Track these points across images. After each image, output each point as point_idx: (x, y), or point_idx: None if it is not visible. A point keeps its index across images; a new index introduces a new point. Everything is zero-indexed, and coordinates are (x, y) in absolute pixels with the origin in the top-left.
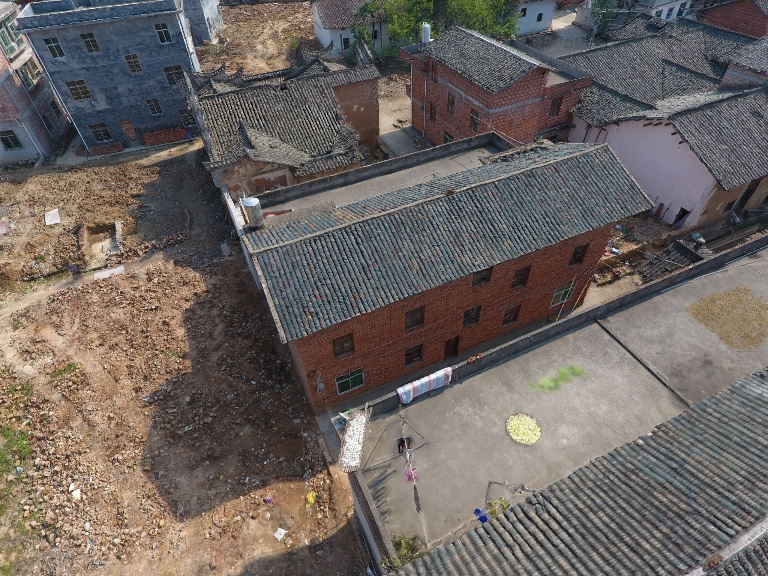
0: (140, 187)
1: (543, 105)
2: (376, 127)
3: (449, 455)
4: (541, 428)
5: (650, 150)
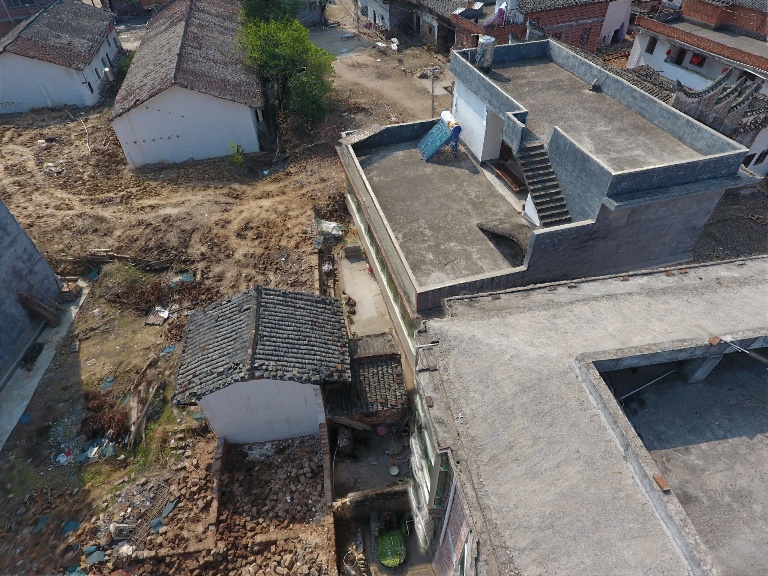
0: None
1: None
2: None
3: None
4: None
5: None
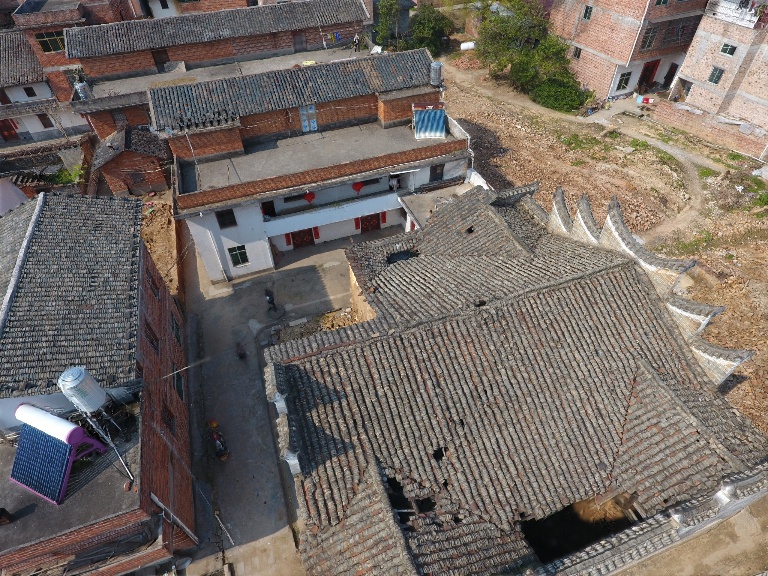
0: None
1: None
2: None
3: None
4: None
5: None
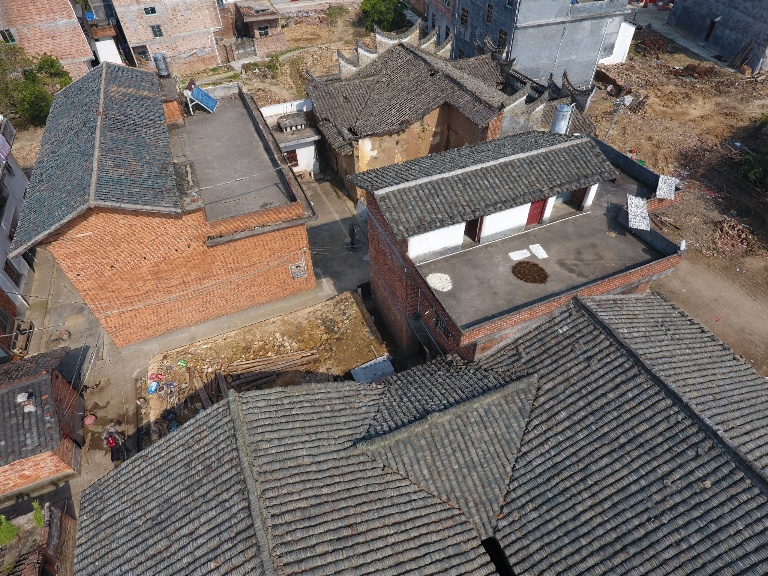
0: None
1: None
2: None
3: None
4: None
5: None
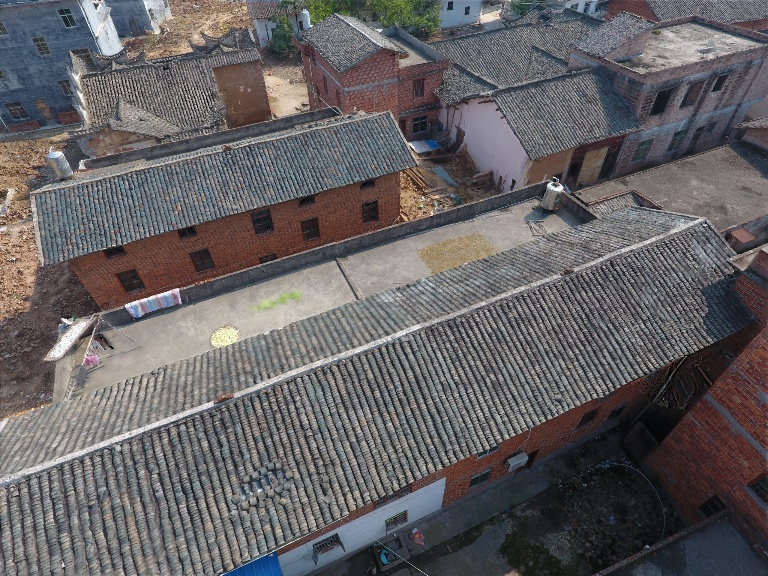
0: (43, 160)
1: (404, 86)
2: (267, 108)
3: (153, 355)
4: (239, 337)
5: (488, 126)
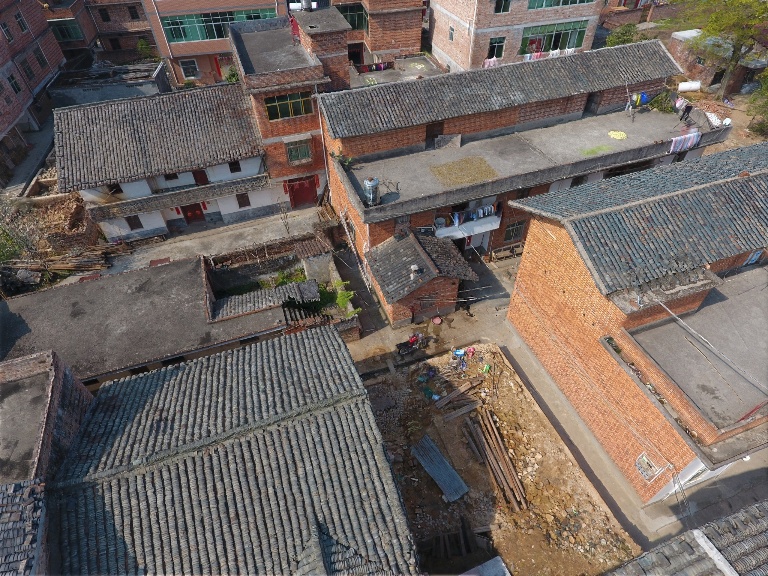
0: None
1: None
2: None
3: None
4: None
5: None
